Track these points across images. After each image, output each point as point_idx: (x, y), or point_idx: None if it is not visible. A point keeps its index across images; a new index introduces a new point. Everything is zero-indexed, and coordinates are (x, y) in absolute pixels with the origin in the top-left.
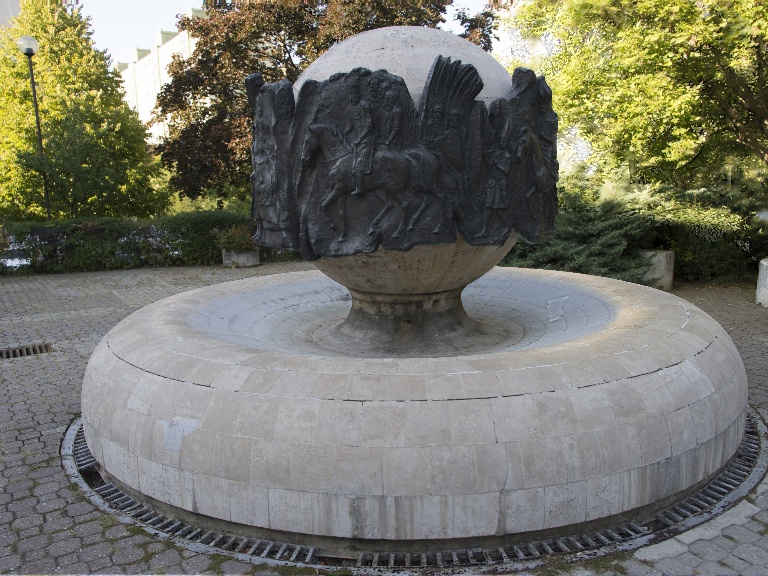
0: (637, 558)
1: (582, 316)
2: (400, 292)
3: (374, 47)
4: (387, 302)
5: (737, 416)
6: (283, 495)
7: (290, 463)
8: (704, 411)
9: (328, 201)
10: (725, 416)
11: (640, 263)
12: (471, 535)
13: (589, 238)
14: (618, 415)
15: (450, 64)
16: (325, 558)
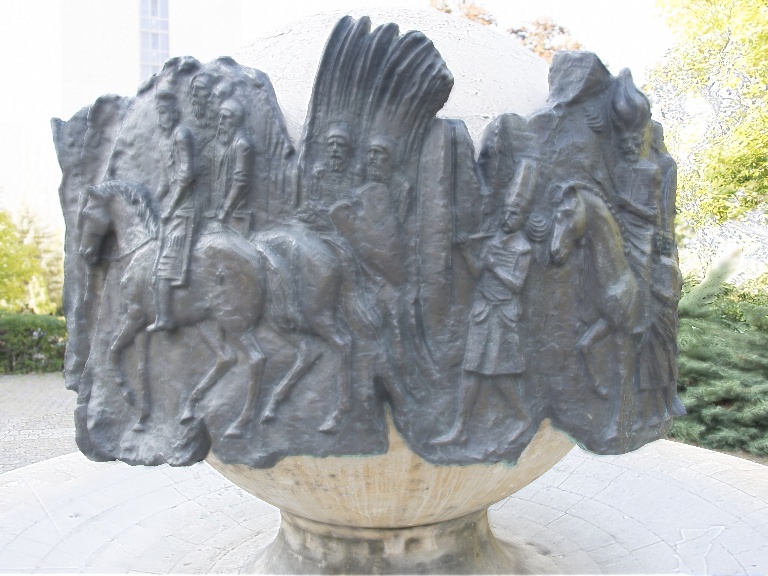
0: None
1: None
2: (328, 521)
3: (268, 34)
4: (315, 532)
5: None
6: None
7: None
8: None
9: (118, 341)
10: None
11: None
12: None
13: None
14: None
15: (368, 33)
16: None
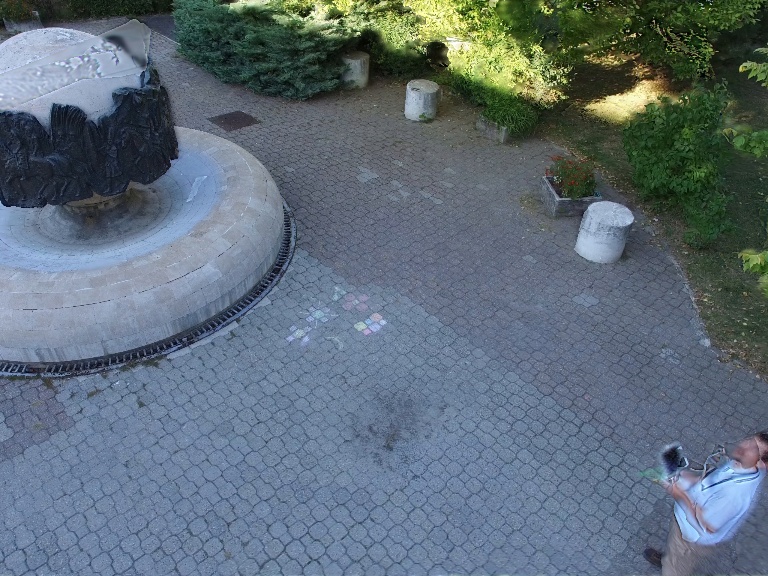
0: (167, 358)
1: (200, 203)
2: None
3: None
4: (75, 206)
5: (243, 280)
6: (4, 349)
7: (3, 338)
8: (212, 288)
9: (9, 180)
10: (230, 285)
11: (338, 72)
12: (93, 357)
13: (299, 52)
14: (158, 303)
15: (61, 108)
16: (33, 368)
